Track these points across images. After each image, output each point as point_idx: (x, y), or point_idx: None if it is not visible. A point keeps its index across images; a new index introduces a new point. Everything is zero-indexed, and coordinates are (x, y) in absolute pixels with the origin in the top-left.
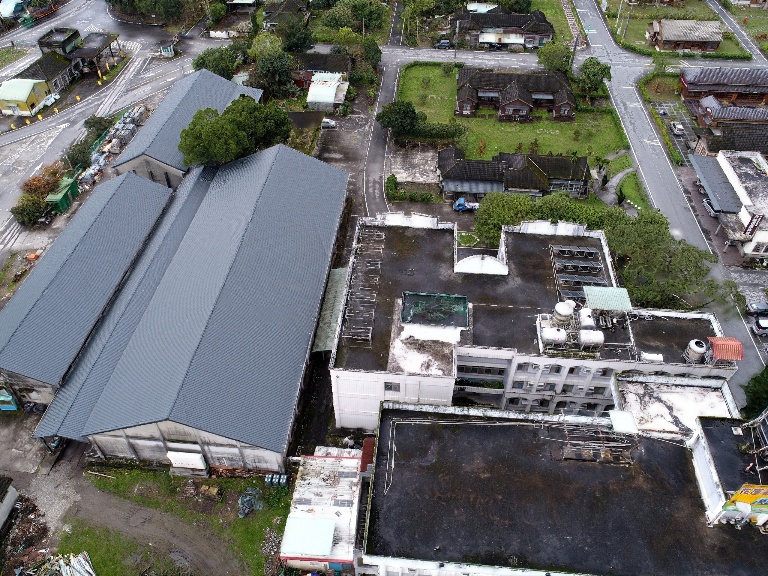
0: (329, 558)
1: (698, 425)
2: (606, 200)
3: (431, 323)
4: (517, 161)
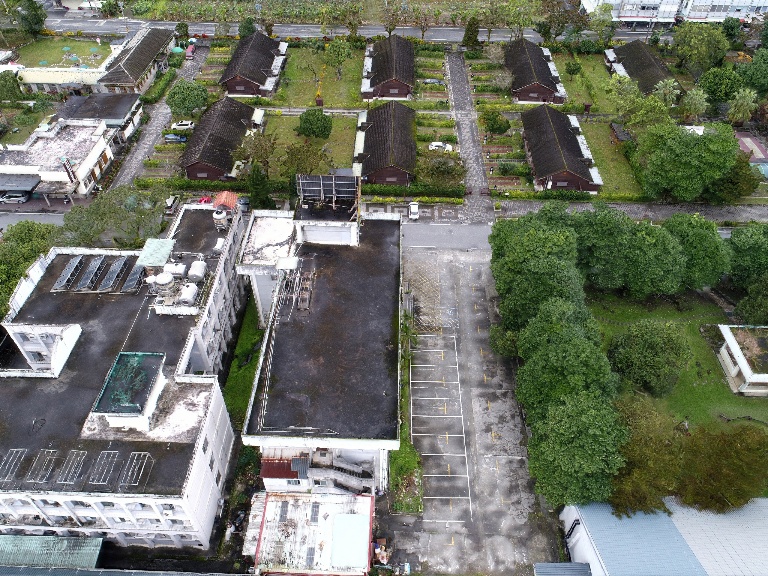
0: (369, 520)
1: (299, 223)
2: None
3: (149, 386)
4: None
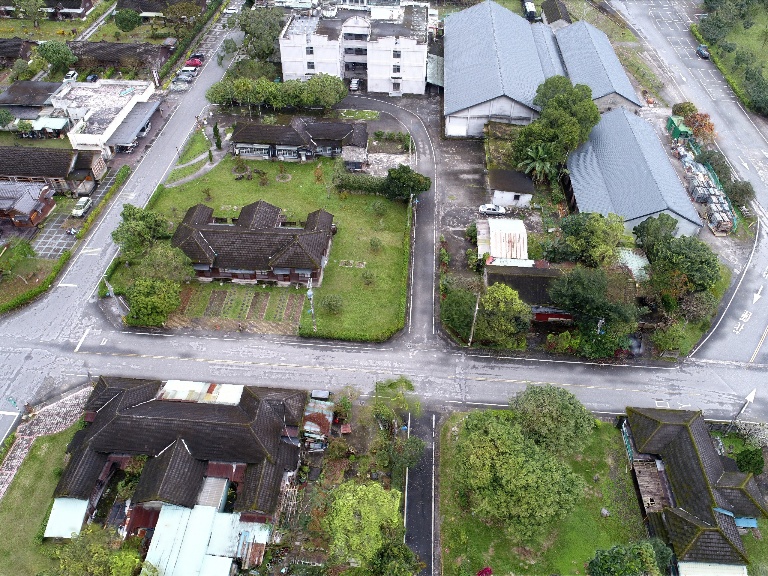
0: None
1: None
2: None
3: None
4: (299, 125)
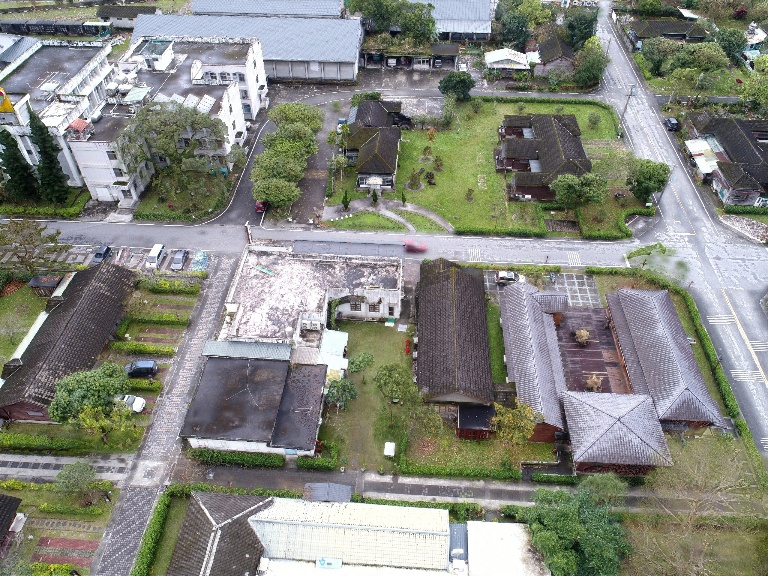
0: None
1: None
2: (354, 202)
3: (147, 47)
4: None
